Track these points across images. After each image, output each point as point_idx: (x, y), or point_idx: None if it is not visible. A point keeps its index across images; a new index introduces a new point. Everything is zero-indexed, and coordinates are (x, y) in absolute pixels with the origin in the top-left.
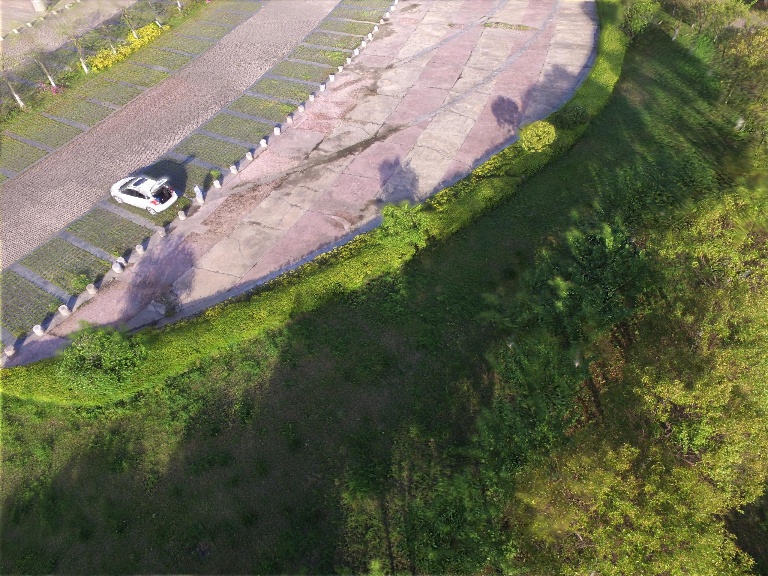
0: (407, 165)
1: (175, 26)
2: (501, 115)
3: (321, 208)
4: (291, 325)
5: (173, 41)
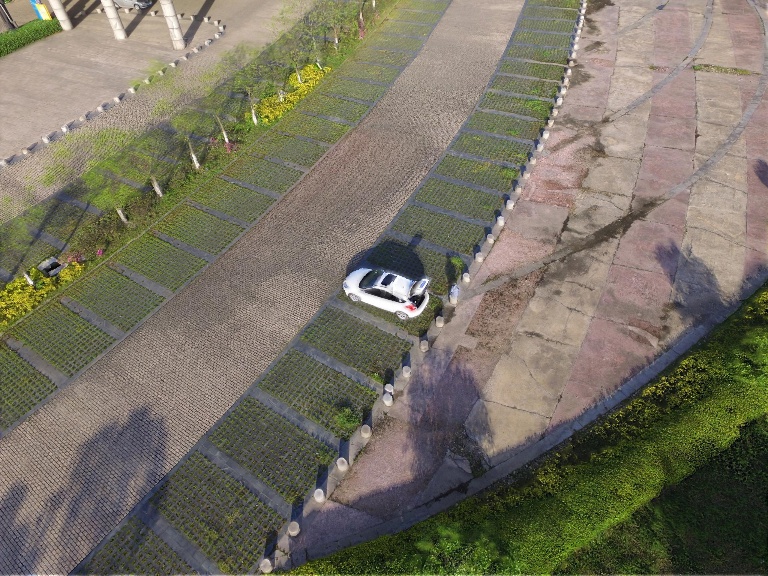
0: (690, 254)
1: (335, 67)
2: None
3: (609, 314)
4: (661, 503)
5: (339, 86)
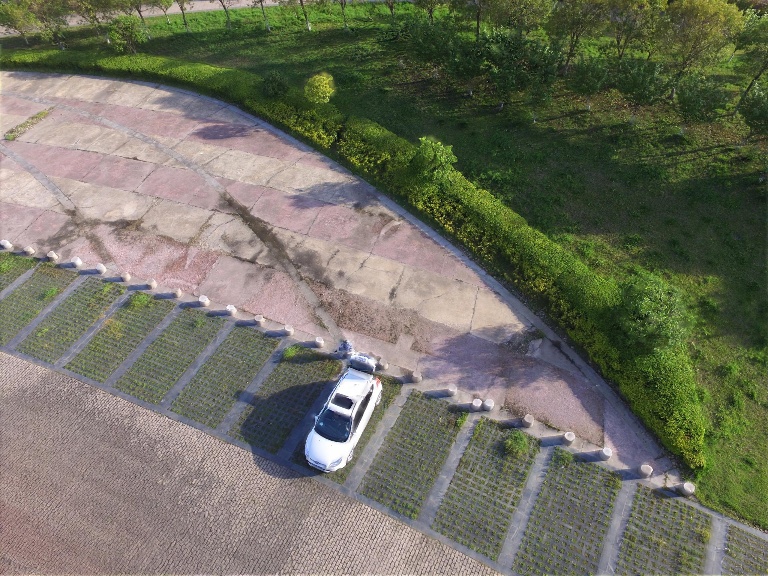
0: (300, 190)
1: None
2: (227, 135)
3: (368, 243)
4: None
5: None
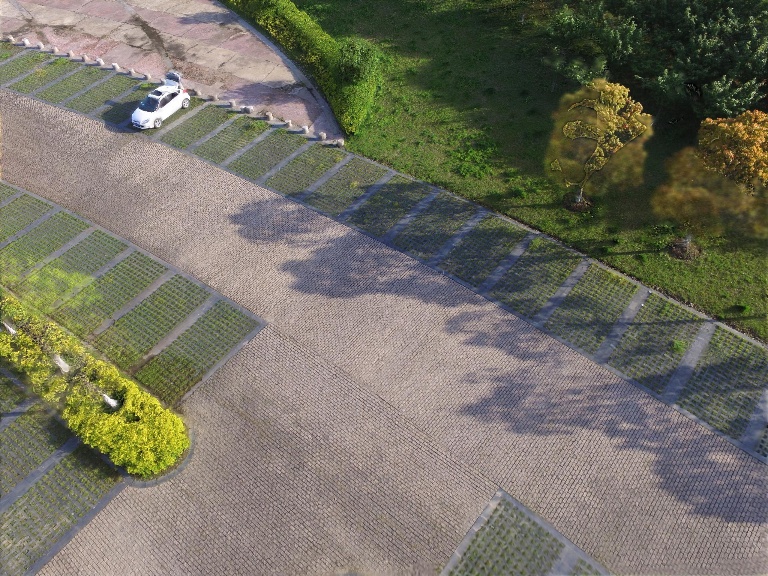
0: (187, 15)
1: None
2: None
3: (219, 42)
4: None
5: None
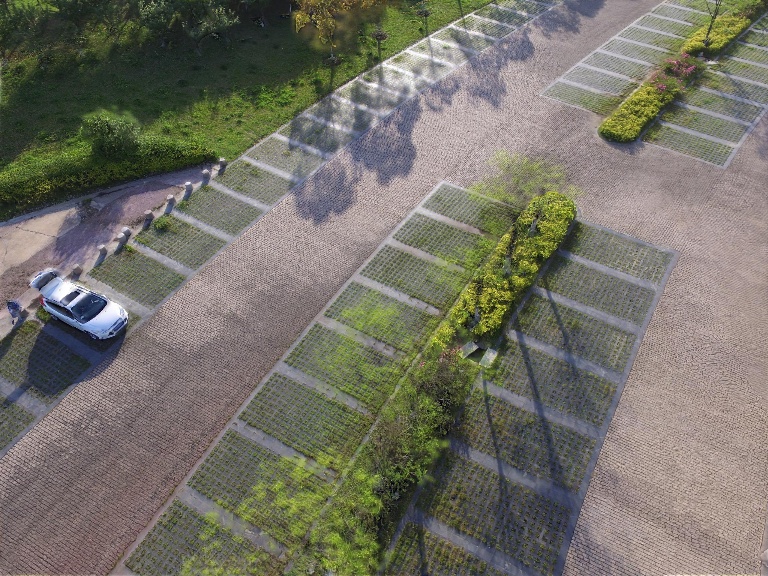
0: None
1: None
2: None
3: None
4: None
5: None
